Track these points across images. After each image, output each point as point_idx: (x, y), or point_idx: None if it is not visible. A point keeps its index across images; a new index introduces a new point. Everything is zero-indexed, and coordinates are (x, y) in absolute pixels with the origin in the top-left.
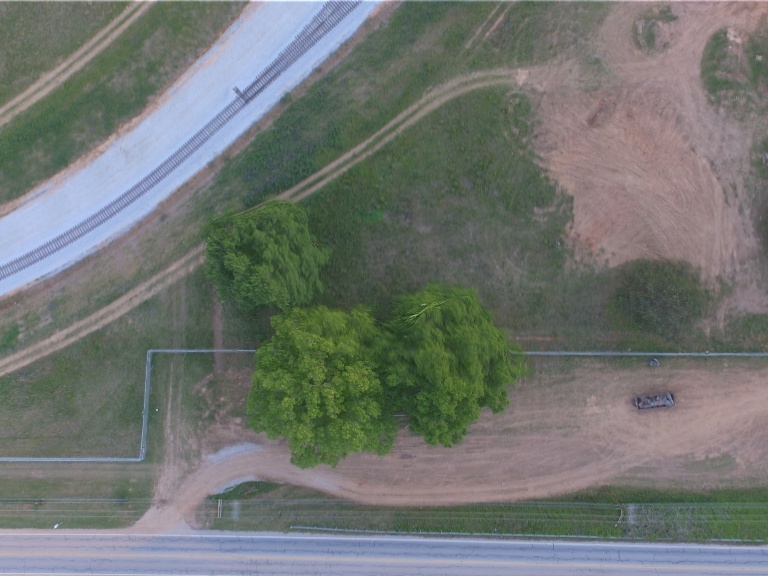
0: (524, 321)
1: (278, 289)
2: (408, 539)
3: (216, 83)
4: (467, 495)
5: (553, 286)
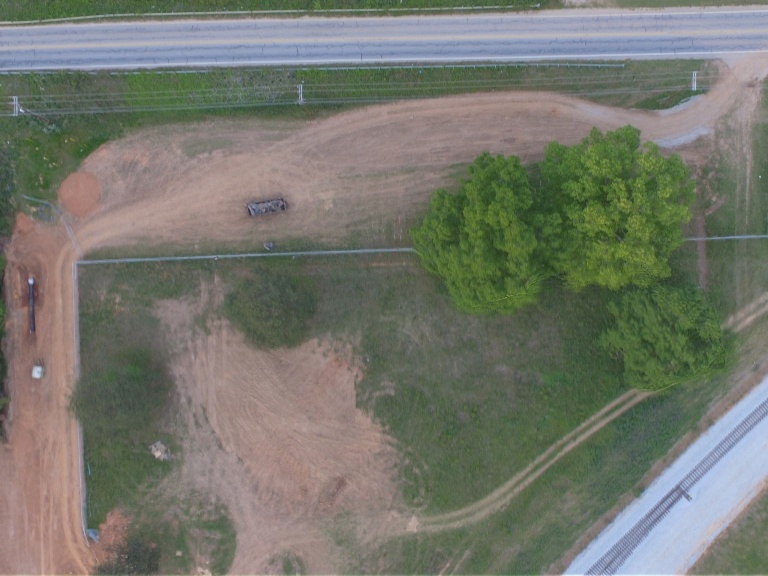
0: (400, 282)
1: (671, 307)
2: (506, 58)
3: (709, 504)
4: (448, 105)
5: (373, 318)
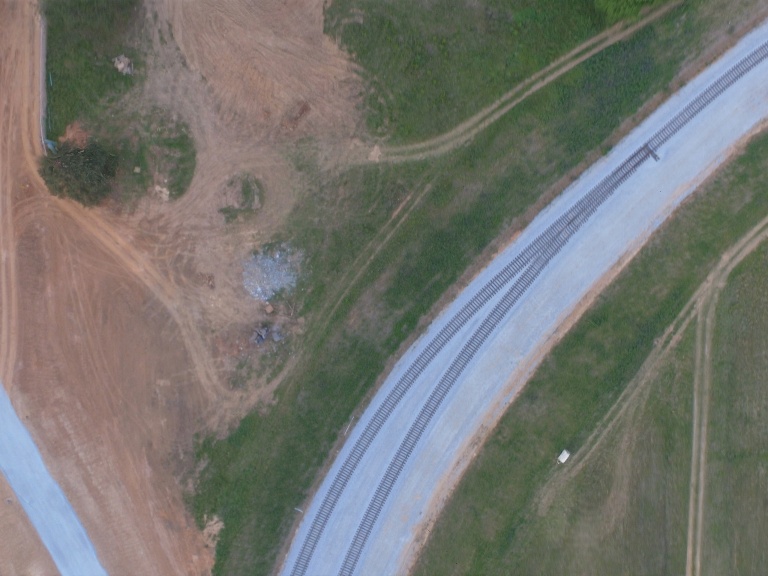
0: None
1: None
2: None
3: (677, 166)
4: None
5: None
